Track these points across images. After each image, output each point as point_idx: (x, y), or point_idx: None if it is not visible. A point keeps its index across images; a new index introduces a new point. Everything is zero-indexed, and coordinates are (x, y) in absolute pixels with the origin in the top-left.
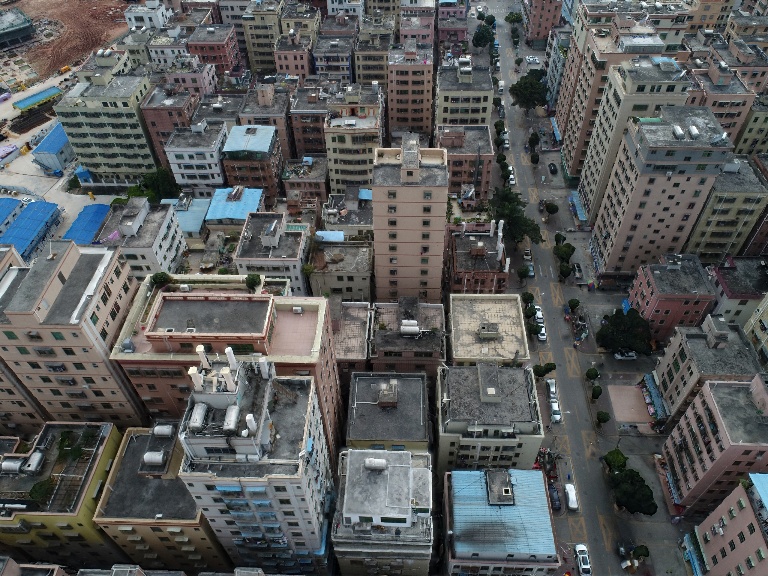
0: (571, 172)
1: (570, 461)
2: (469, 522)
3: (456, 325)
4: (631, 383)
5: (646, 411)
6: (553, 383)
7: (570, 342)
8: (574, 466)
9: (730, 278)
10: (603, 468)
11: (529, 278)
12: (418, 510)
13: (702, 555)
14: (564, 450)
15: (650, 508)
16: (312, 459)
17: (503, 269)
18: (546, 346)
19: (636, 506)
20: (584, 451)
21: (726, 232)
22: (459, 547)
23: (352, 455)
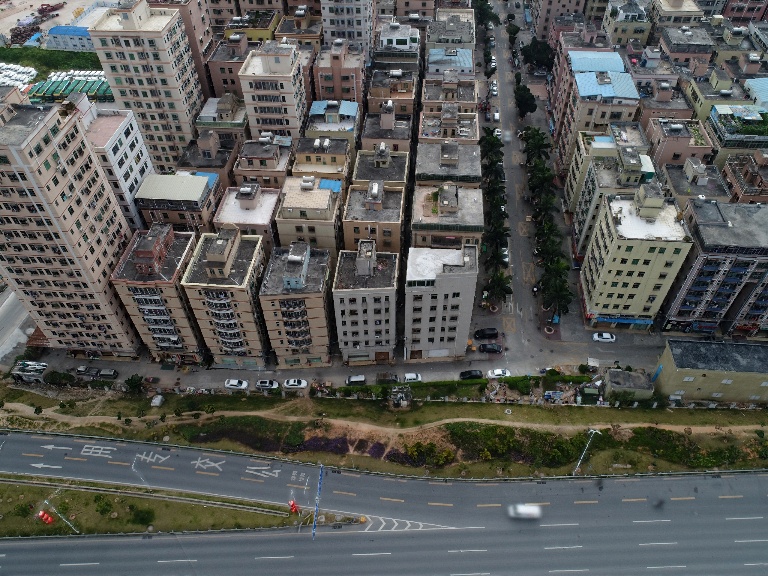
0: (527, 1)
1: (499, 108)
2: (435, 60)
3: (439, 19)
4: (541, 84)
5: (546, 93)
6: (495, 80)
7: (510, 70)
8: (501, 109)
9: (600, 23)
10: (516, 109)
11: (491, 47)
12: (412, 39)
13: (554, 117)
14: (497, 104)
15: (533, 105)
16: (369, 1)
17: (468, 6)
18: (495, 71)
19: (526, 105)
20: (508, 105)
21: (605, 7)
22: (430, 65)
23: (384, 25)
